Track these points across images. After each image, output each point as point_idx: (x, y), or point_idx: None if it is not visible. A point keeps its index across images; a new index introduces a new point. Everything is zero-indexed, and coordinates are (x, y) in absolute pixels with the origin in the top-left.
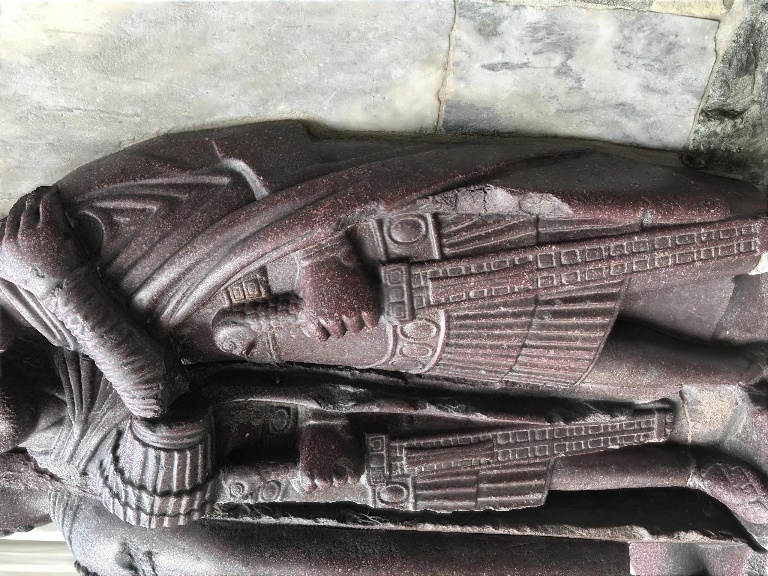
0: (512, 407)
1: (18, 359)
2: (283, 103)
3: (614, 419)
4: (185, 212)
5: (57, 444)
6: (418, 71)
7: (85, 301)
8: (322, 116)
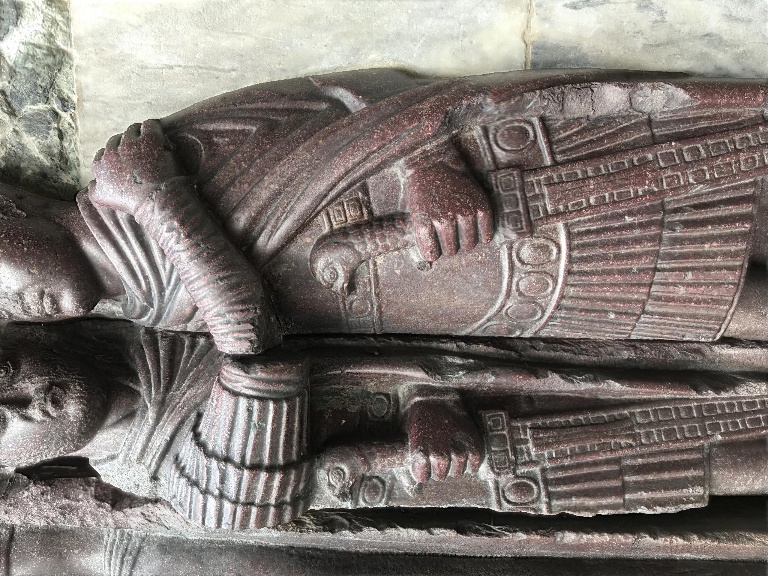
0: (647, 376)
1: (90, 355)
2: (374, 51)
3: None
4: (284, 132)
5: (128, 437)
6: (503, 13)
7: (183, 206)
8: (412, 63)
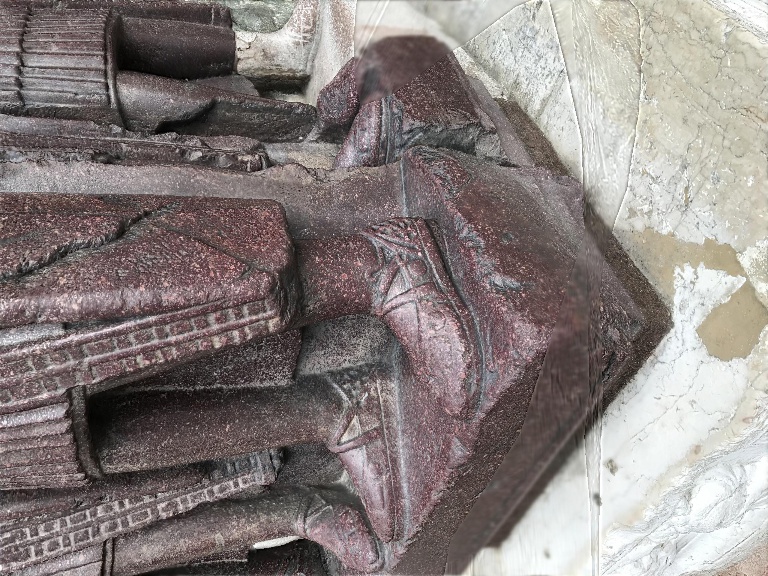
0: None
1: None
2: None
3: (186, 144)
4: None
5: None
6: None
7: None
8: None
